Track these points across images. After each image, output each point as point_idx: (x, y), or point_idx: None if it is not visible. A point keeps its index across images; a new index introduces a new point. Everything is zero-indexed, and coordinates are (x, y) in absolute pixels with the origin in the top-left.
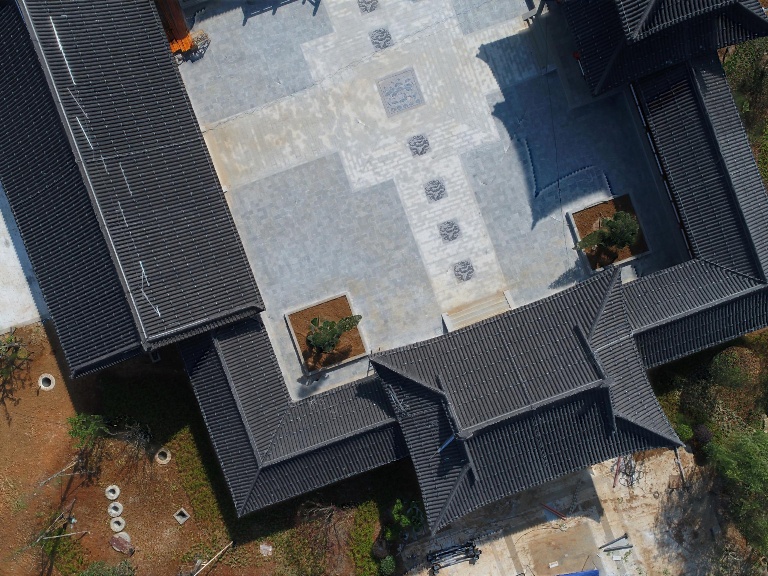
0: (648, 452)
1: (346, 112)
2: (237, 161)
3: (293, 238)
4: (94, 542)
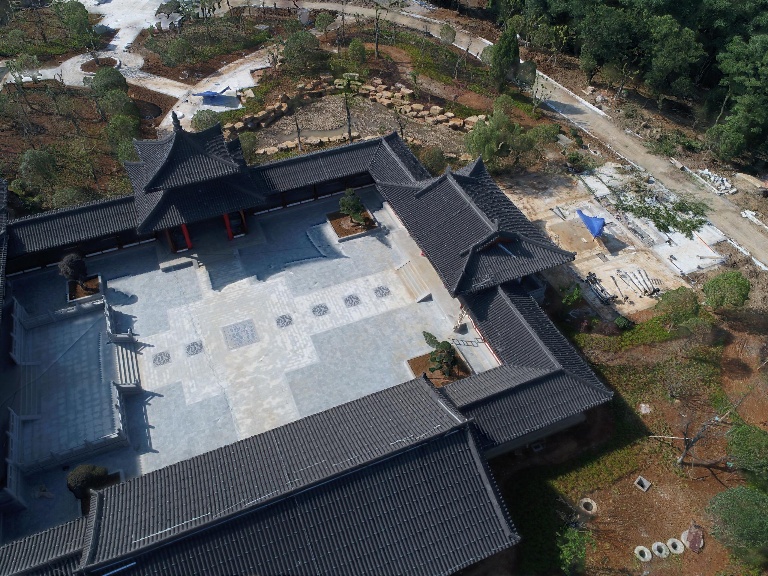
0: None
1: (252, 369)
2: None
3: None
4: (705, 570)
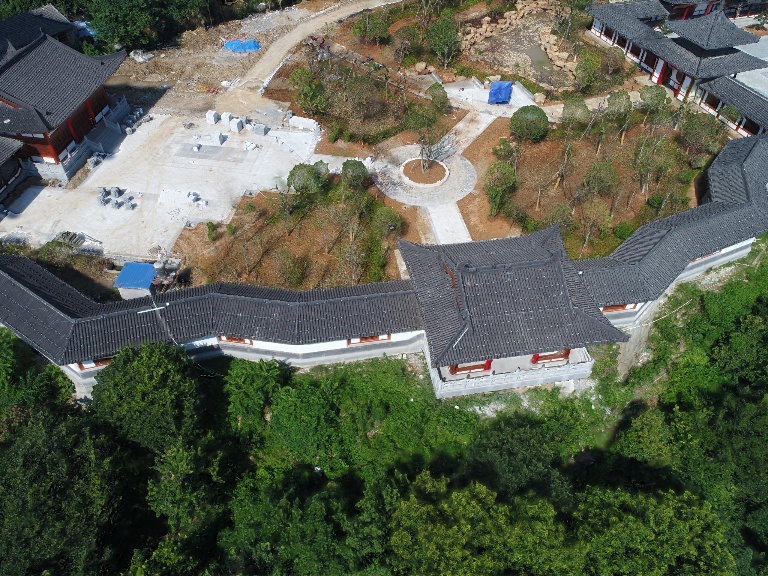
0: None
1: None
2: None
3: None
4: None
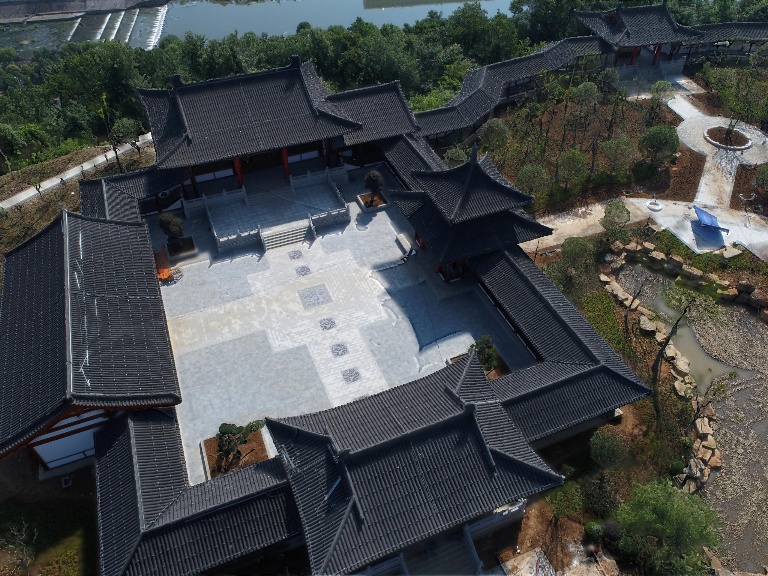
0: (566, 560)
1: (274, 308)
2: (185, 338)
3: (219, 385)
4: None
